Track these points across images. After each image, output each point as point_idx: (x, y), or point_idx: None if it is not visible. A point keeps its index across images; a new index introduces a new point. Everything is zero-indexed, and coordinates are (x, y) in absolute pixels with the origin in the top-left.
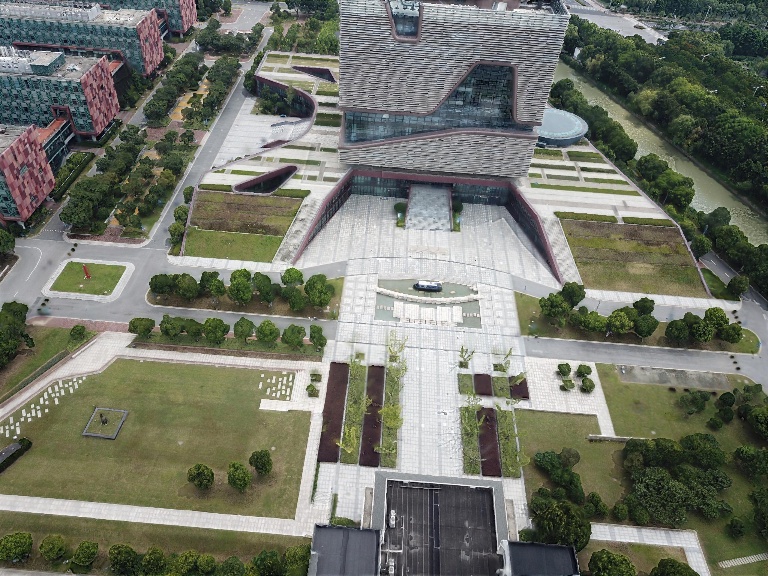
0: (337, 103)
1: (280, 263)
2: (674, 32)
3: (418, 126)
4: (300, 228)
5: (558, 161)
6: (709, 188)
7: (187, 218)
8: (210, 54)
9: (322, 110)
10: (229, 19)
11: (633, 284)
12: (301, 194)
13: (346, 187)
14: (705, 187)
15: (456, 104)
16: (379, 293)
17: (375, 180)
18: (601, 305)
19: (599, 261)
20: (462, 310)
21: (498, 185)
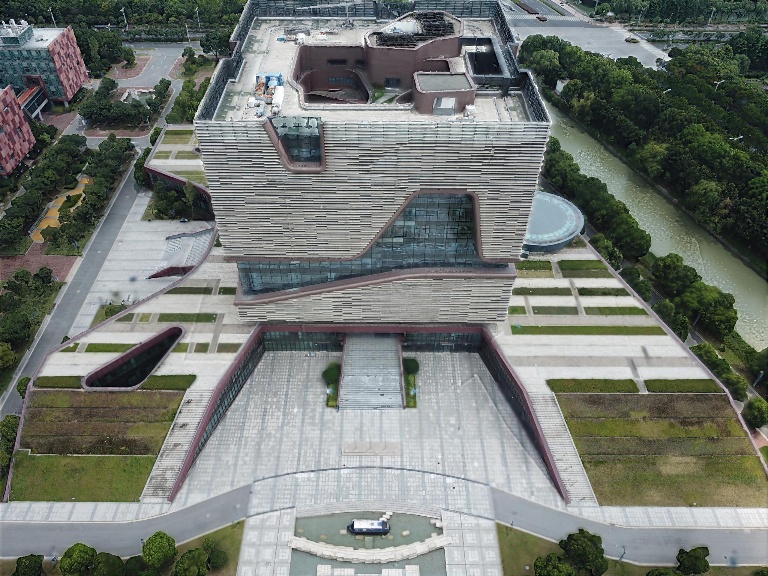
0: None
1: (151, 501)
2: (676, 48)
3: (343, 270)
4: (181, 439)
5: (547, 280)
6: (748, 284)
7: (15, 437)
8: (100, 128)
9: None
10: (132, 72)
11: (669, 492)
12: (181, 384)
13: (254, 349)
14: (743, 283)
15: (393, 242)
16: (295, 549)
17: (295, 334)
18: (626, 539)
19: (617, 457)
20: (419, 573)
21: (466, 331)
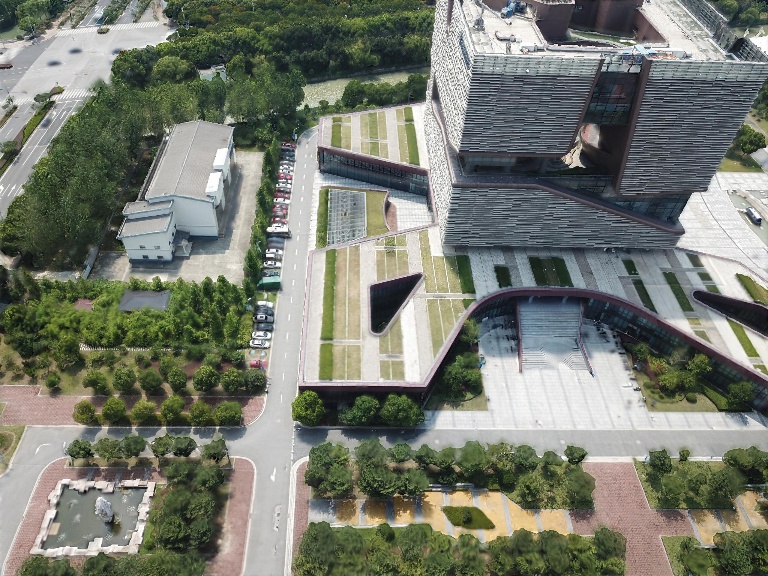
0: (496, 267)
1: None
2: (169, 8)
3: None
4: None
5: None
6: None
7: None
8: (206, 558)
9: (523, 282)
10: None
11: None
12: (751, 280)
13: None
14: None
15: None
16: None
17: None
18: None
19: None
20: (764, 199)
21: None
